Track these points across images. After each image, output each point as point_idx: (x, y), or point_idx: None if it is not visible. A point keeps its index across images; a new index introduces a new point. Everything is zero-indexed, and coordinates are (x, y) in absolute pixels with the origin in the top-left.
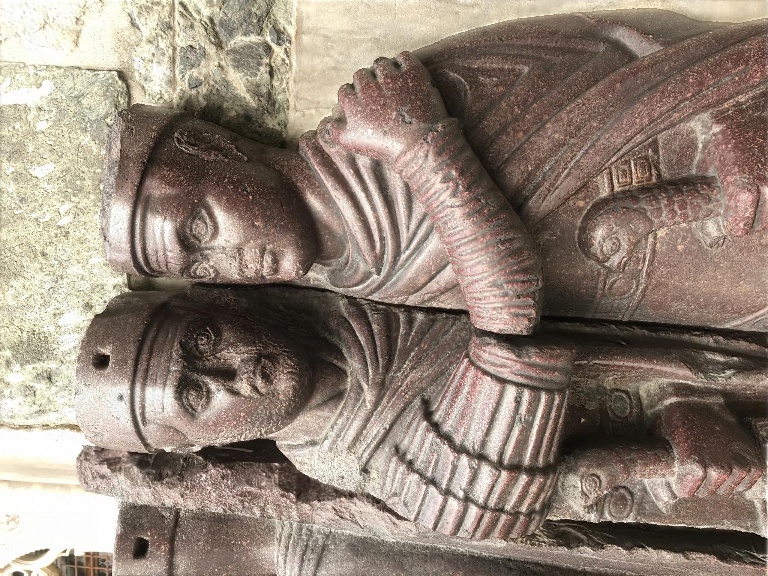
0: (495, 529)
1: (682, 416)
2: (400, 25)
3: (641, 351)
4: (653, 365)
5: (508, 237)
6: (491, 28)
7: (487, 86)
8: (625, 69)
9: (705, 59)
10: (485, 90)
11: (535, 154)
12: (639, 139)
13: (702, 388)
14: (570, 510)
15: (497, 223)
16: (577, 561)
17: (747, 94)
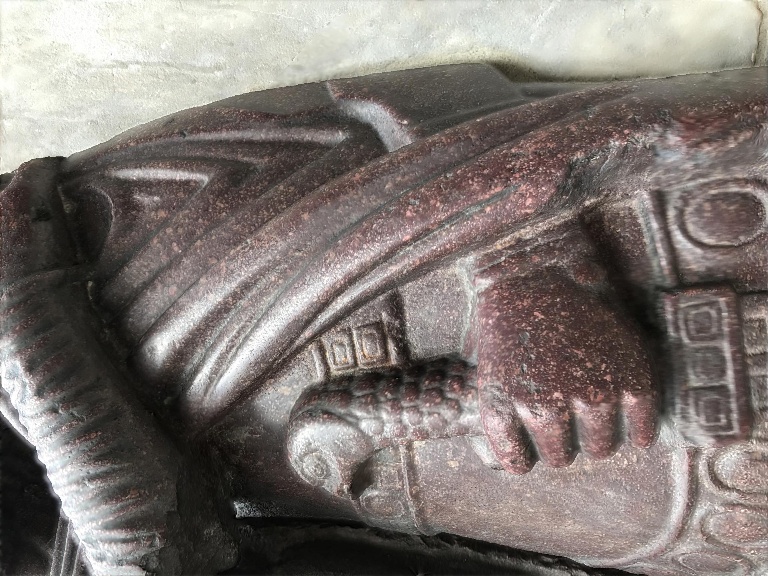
0: None
1: None
2: (122, 102)
3: None
4: None
5: (101, 469)
6: (183, 114)
7: (144, 209)
8: (323, 188)
9: (441, 174)
10: (140, 215)
11: (182, 324)
12: (341, 305)
13: None
14: None
15: (84, 446)
16: None
17: (536, 227)
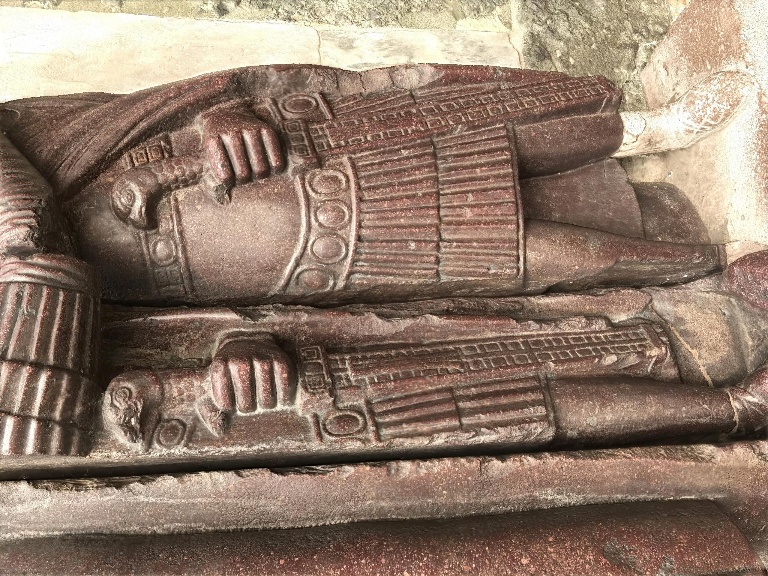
0: (4, 437)
1: (226, 345)
2: None
3: None
4: (203, 314)
5: (15, 171)
6: None
7: (37, 114)
8: None
9: None
10: (34, 116)
11: (59, 138)
12: (142, 126)
13: (254, 332)
14: (116, 443)
15: (6, 162)
16: (139, 515)
17: (227, 104)
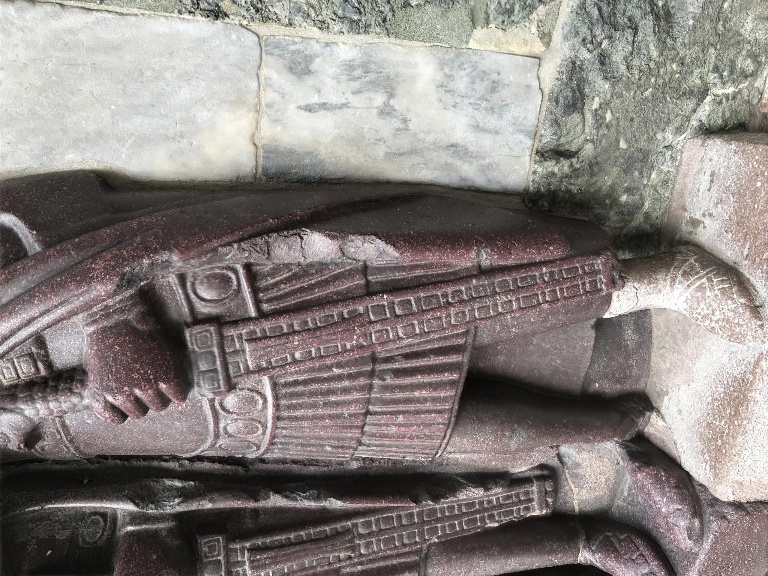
0: None
1: (128, 547)
2: None
3: (95, 491)
4: (104, 504)
5: None
6: None
7: None
8: None
9: (54, 278)
10: None
11: None
12: (2, 350)
13: (157, 514)
14: None
15: None
16: None
17: (115, 298)
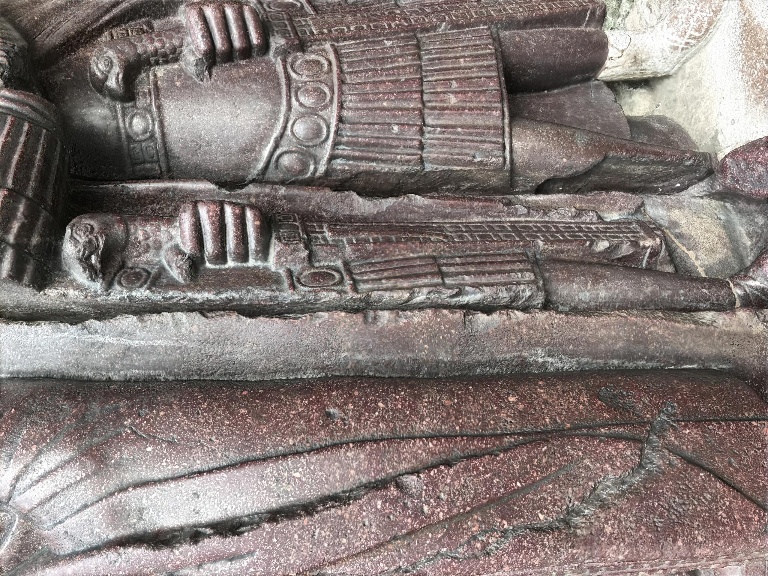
0: None
1: None
2: None
3: None
4: (177, 182)
5: None
6: None
7: None
8: None
9: None
10: None
11: (41, 11)
12: (124, 6)
13: None
14: (74, 283)
15: None
16: (94, 358)
17: None
